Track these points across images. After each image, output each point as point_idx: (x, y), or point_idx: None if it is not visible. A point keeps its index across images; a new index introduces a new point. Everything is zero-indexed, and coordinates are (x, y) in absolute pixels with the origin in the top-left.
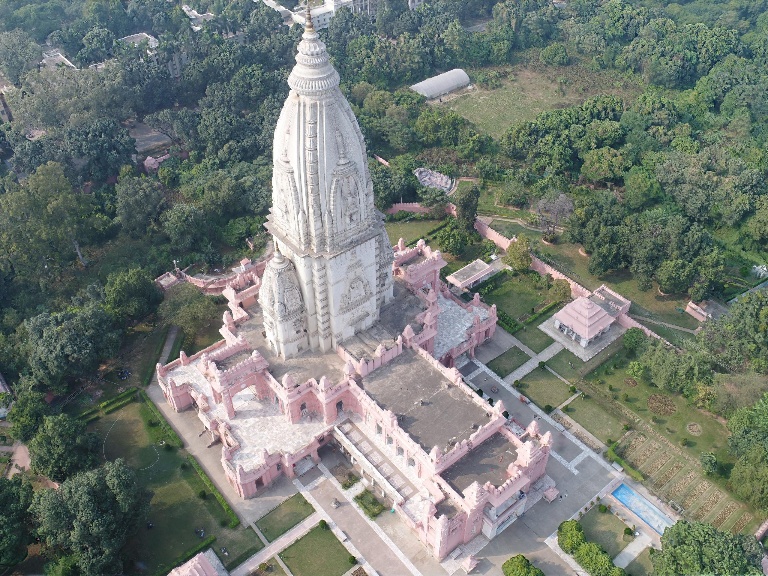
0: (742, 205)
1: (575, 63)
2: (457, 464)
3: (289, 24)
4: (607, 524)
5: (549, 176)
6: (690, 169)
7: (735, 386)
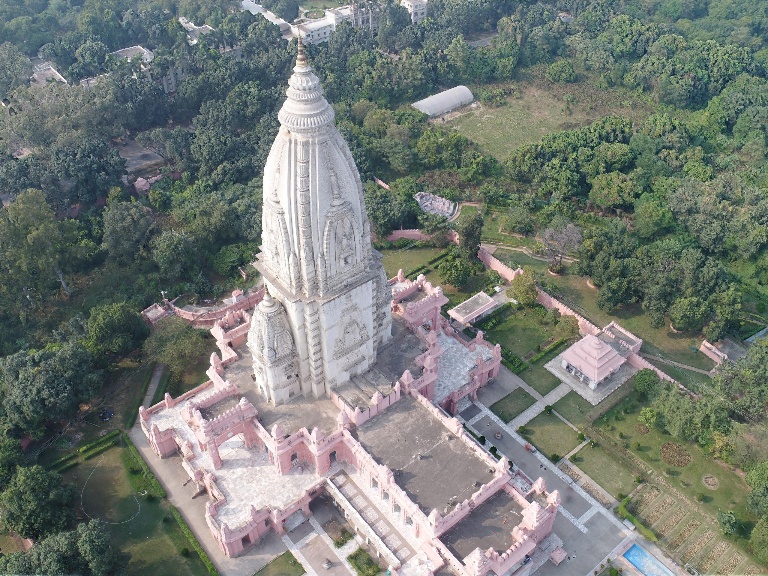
0: (759, 237)
1: (582, 80)
2: (458, 526)
3: (288, 38)
4: None
5: (556, 202)
6: (704, 198)
7: (755, 438)
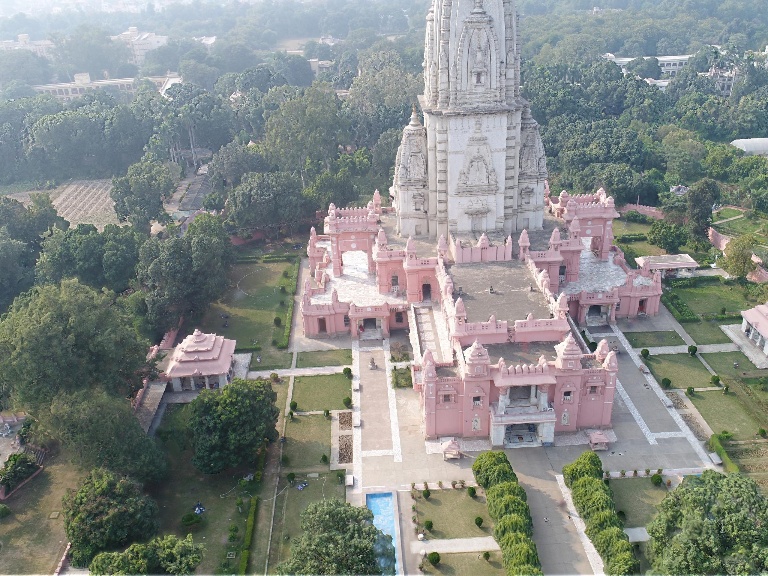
0: None
1: None
2: (489, 346)
3: None
4: (652, 497)
5: None
6: None
7: None
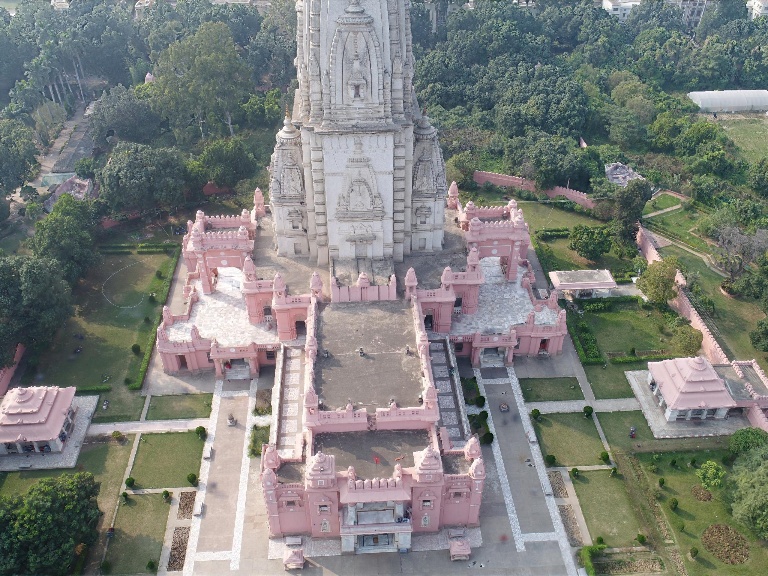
0: None
1: None
2: (346, 434)
3: None
4: None
5: None
6: None
7: None
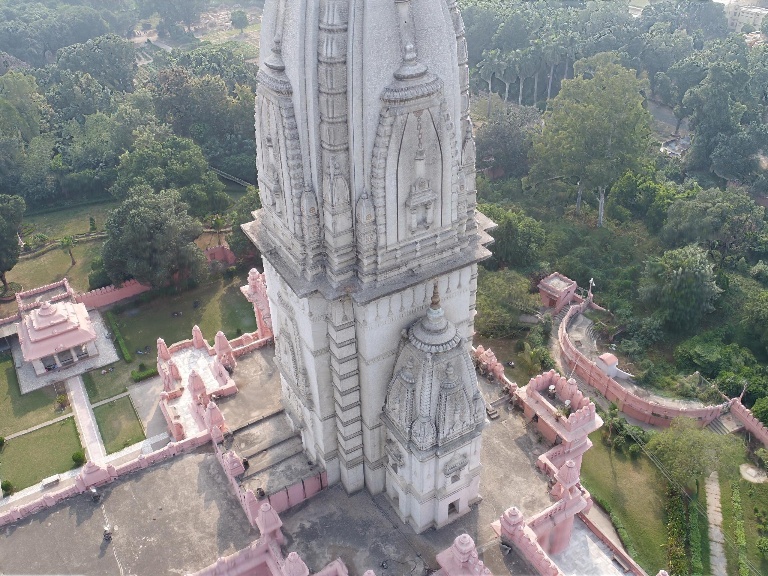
0: None
1: None
2: None
3: None
4: None
5: None
6: None
7: None
